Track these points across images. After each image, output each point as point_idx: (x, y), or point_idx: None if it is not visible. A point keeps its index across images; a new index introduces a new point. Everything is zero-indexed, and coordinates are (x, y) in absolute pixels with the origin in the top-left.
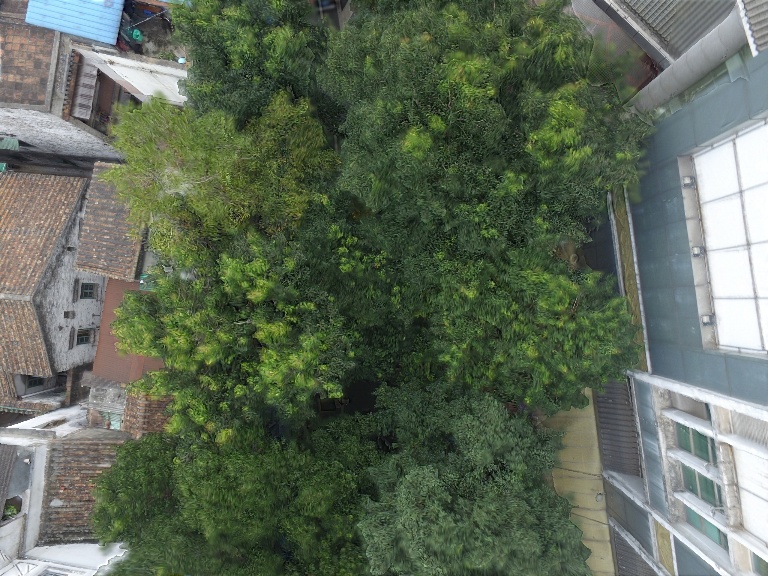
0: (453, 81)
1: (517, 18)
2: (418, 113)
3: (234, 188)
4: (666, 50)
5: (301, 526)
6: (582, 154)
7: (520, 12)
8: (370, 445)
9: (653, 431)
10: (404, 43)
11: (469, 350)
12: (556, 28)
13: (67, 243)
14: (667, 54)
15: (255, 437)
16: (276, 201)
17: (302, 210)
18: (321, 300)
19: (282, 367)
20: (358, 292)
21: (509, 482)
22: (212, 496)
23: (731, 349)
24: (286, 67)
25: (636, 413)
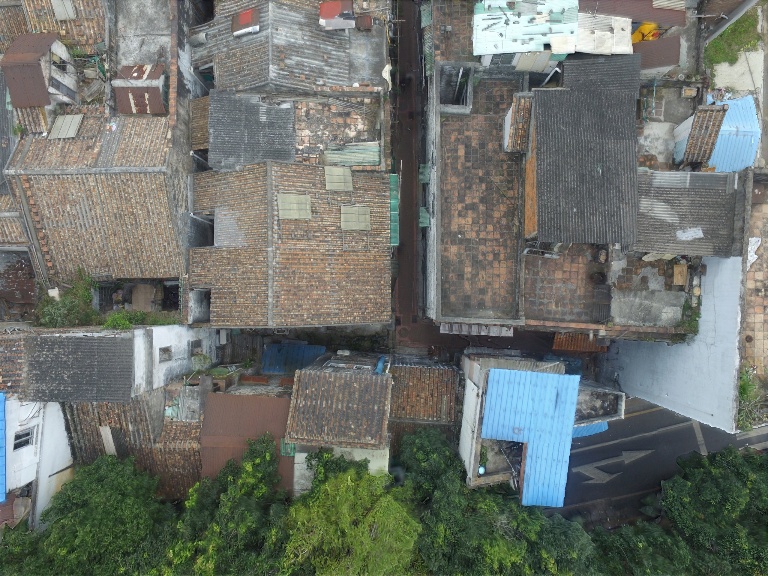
0: None
1: None
2: None
3: None
4: None
5: None
6: None
7: None
8: None
9: None
10: None
11: None
12: None
13: None
14: None
15: None
16: None
17: None
18: None
19: None
20: None
21: None
22: None
23: None
24: None
25: None
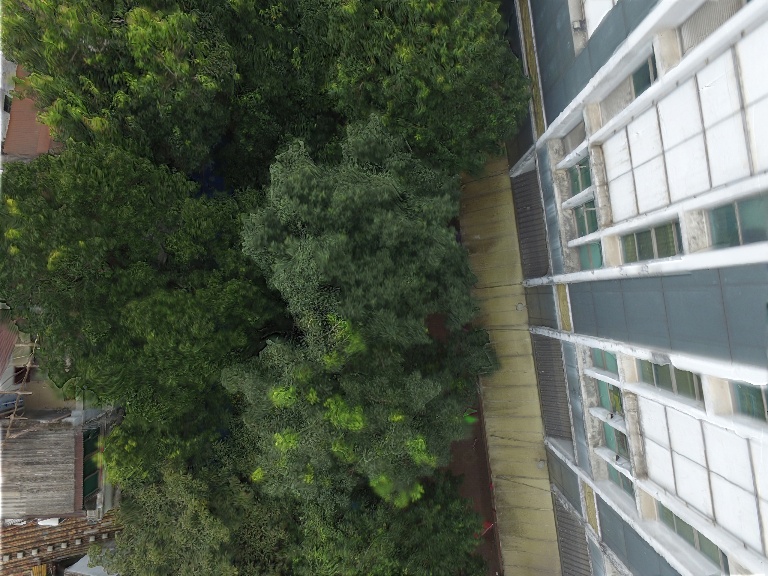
0: None
1: None
2: None
3: None
4: None
5: (187, 241)
6: None
7: None
8: None
9: (551, 192)
10: None
11: (362, 94)
12: None
13: None
14: None
15: (142, 156)
16: None
17: None
18: (206, 22)
19: (146, 32)
20: (257, 49)
21: None
22: (81, 164)
23: None
24: None
25: (540, 189)
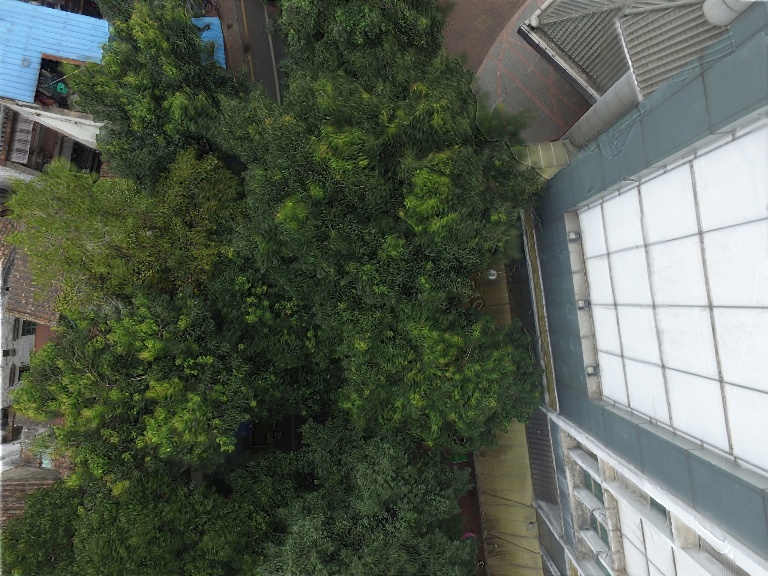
0: (321, 156)
1: (403, 82)
2: (299, 180)
3: (140, 244)
4: (594, 87)
5: (205, 570)
6: (449, 222)
7: (407, 76)
8: (287, 484)
9: (563, 469)
10: (266, 124)
11: (376, 395)
12: (435, 95)
13: (5, 284)
14: (594, 91)
15: (161, 484)
16: (183, 255)
17: (211, 262)
18: (224, 352)
19: (167, 426)
20: (272, 337)
21: (398, 529)
22: (103, 549)
23: (609, 401)
24: (188, 128)
25: (552, 449)
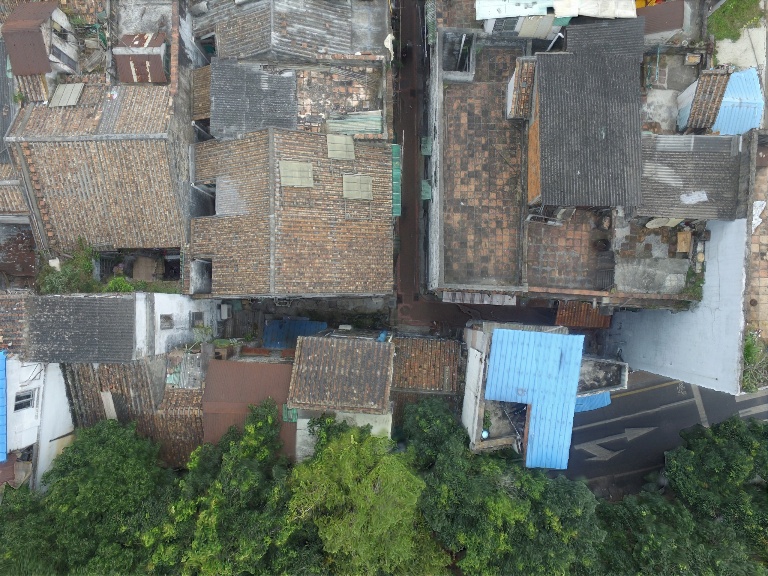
0: None
1: None
2: None
3: None
4: None
5: None
6: None
7: None
8: None
9: None
10: None
11: None
12: None
13: None
14: None
15: None
16: (354, 570)
17: None
18: None
19: None
20: None
21: None
22: None
23: None
24: None
25: None
